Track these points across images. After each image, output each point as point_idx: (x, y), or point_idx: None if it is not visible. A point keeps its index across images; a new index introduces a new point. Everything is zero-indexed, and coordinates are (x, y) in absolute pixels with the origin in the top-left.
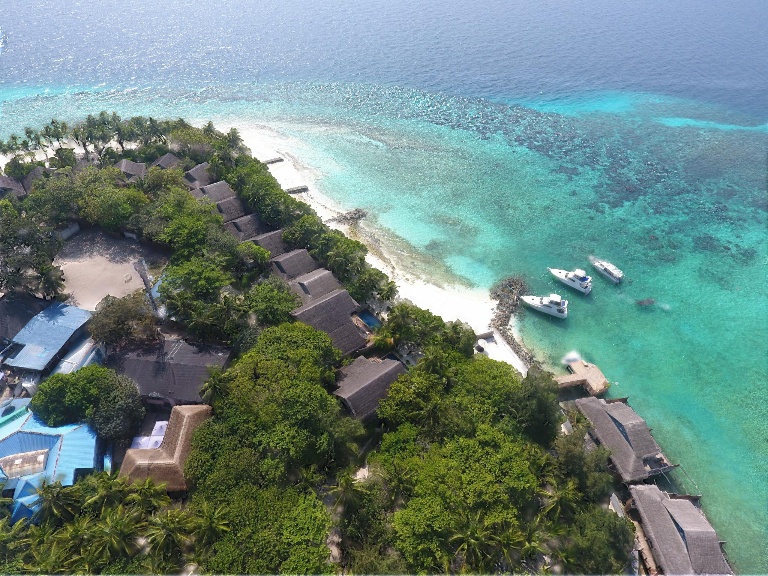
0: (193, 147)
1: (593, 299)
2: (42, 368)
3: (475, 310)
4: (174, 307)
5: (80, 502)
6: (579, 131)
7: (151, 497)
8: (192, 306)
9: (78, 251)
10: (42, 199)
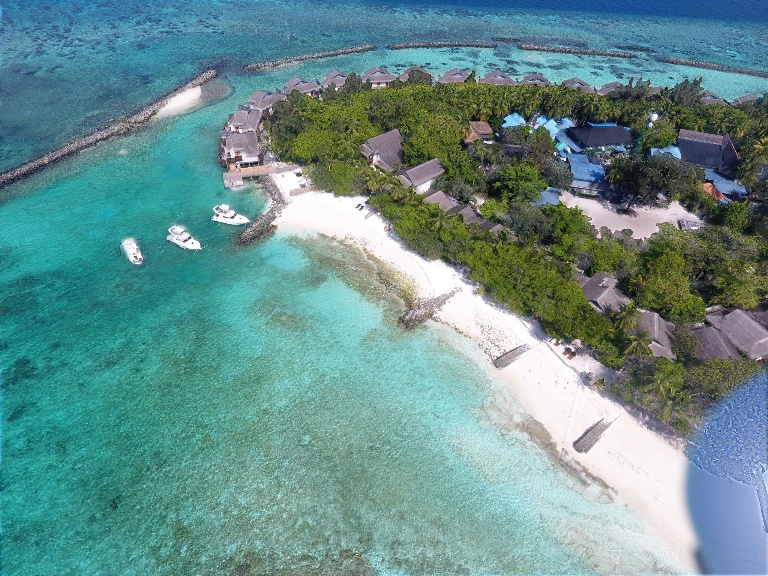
0: None
1: None
2: (567, 154)
3: (296, 214)
4: None
5: (494, 110)
6: None
7: None
8: None
9: None
10: None
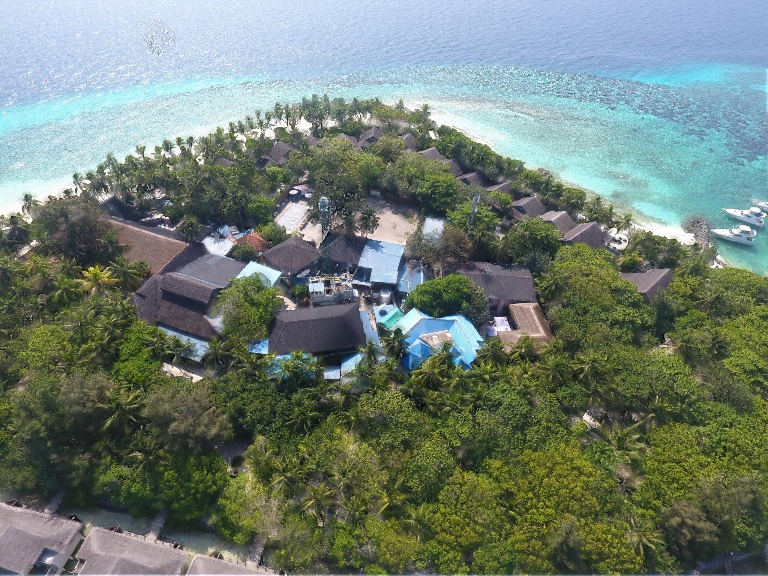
0: (393, 121)
1: (767, 231)
2: None
3: None
4: (471, 238)
5: None
6: (691, 99)
7: None
8: (487, 236)
9: None
10: (312, 164)
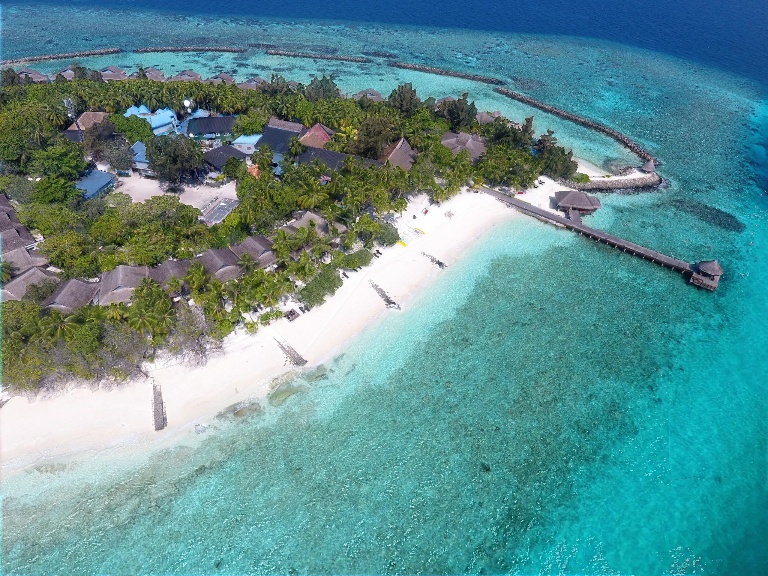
0: None
1: None
2: None
3: None
4: None
5: (120, 102)
6: None
7: None
8: None
9: None
10: (185, 205)
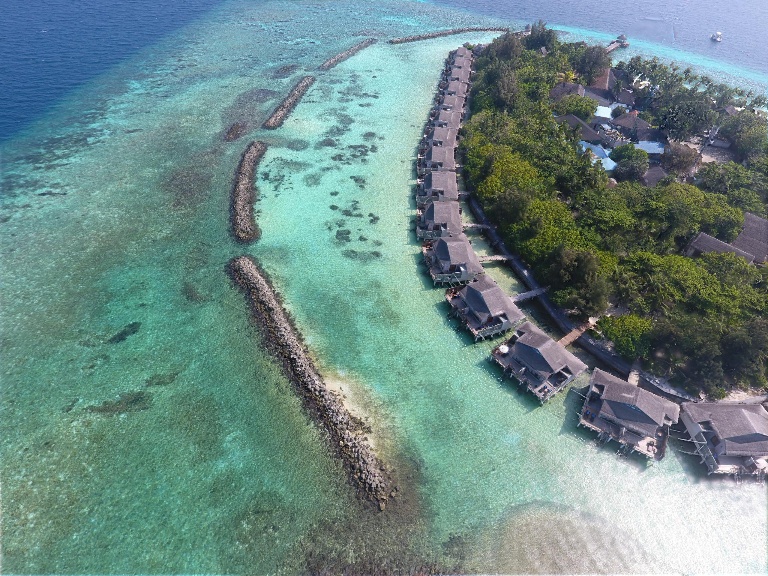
0: None
1: None
2: None
3: None
4: None
5: None
6: None
7: (602, 175)
8: None
9: (711, 152)
10: (732, 118)
